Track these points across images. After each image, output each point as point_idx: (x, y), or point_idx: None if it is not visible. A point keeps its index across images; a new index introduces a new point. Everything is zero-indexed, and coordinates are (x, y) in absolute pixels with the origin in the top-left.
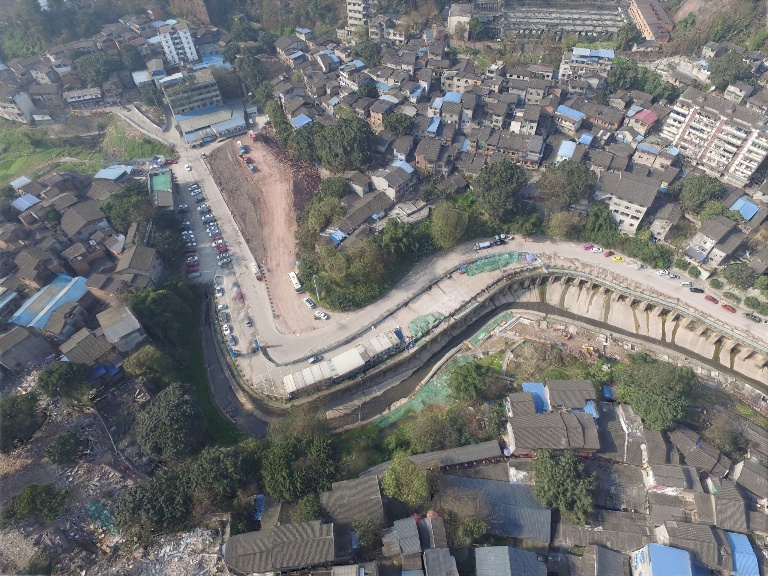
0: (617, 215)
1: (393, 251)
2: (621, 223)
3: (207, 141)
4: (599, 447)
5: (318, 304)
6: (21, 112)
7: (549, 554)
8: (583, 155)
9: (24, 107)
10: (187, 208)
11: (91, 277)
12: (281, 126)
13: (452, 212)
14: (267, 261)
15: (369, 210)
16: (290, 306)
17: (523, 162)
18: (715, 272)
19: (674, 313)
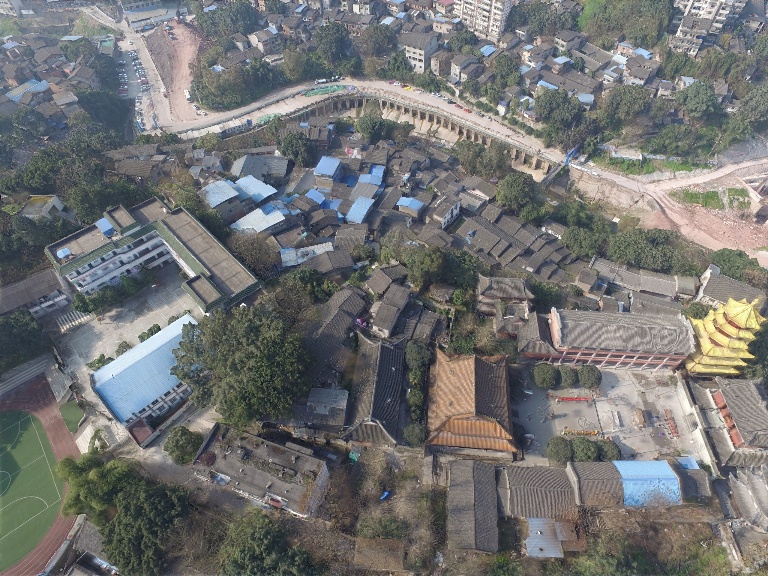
0: (411, 60)
1: (251, 74)
2: (415, 67)
3: (147, 29)
4: (326, 139)
5: (201, 107)
6: (12, 6)
7: (283, 179)
8: (400, 27)
9: (14, 3)
10: (125, 63)
11: (50, 78)
12: (200, 16)
13: (294, 53)
14: (172, 86)
15: (244, 56)
16: (182, 109)
17: None
18: (465, 91)
19: (435, 116)
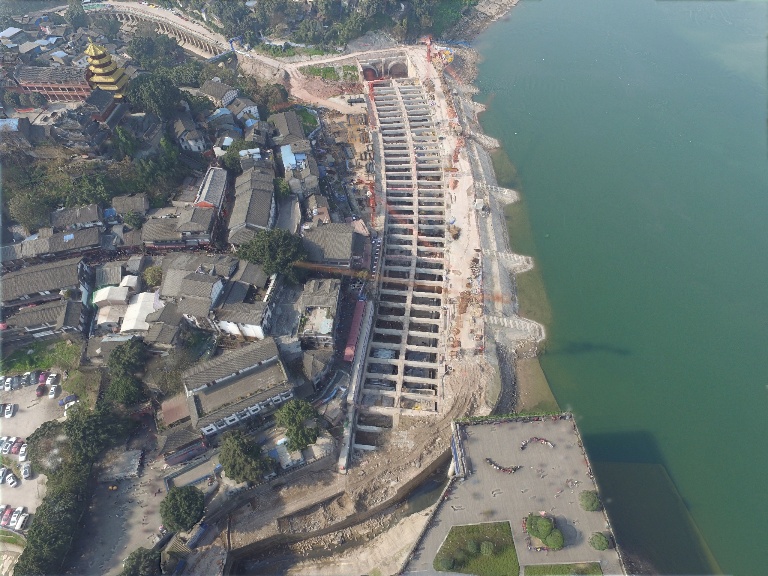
0: None
1: None
2: None
3: None
4: None
5: None
6: None
7: None
8: None
9: None
10: None
11: None
12: None
13: None
14: None
15: None
16: None
17: None
18: None
19: (164, 25)
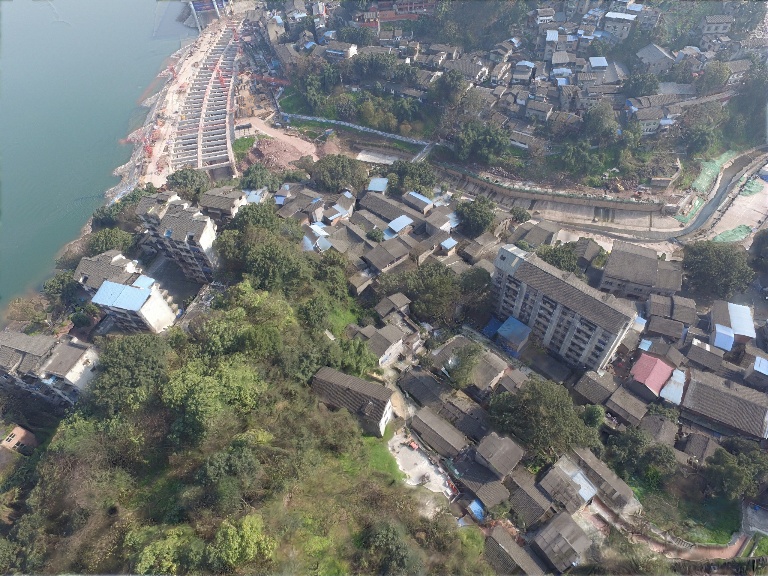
0: None
1: None
2: None
3: None
4: None
5: None
6: None
7: None
8: None
9: None
10: None
11: None
12: None
13: None
14: None
15: None
16: None
17: None
18: None
19: None
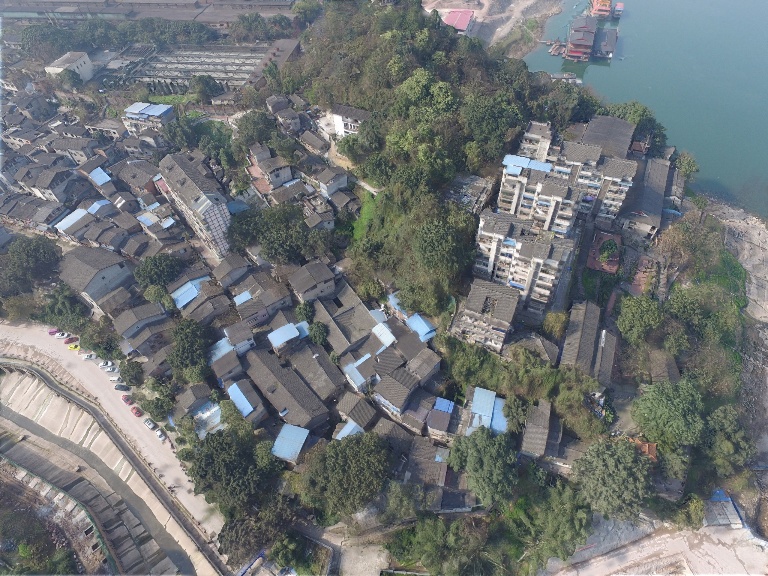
0: (84, 297)
1: None
2: (93, 305)
3: None
4: None
5: None
6: None
7: None
8: None
9: None
10: None
11: None
12: None
13: None
14: None
15: None
16: None
17: (44, 231)
18: None
19: None
